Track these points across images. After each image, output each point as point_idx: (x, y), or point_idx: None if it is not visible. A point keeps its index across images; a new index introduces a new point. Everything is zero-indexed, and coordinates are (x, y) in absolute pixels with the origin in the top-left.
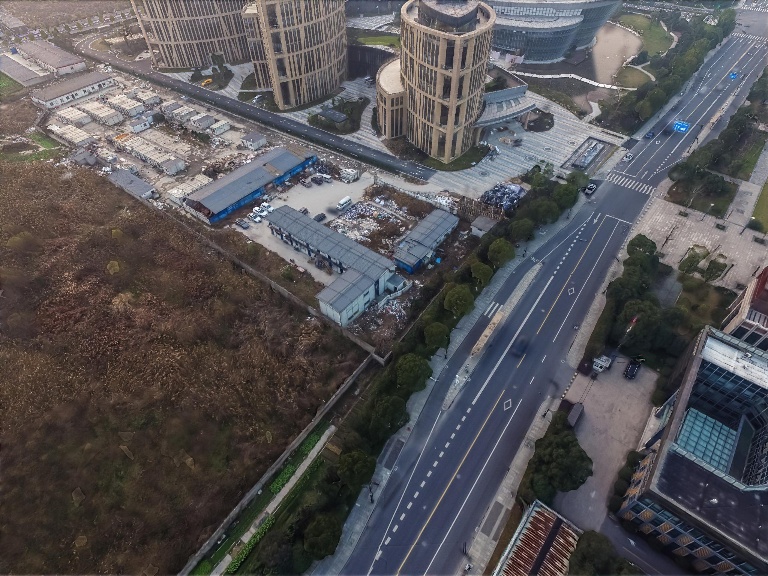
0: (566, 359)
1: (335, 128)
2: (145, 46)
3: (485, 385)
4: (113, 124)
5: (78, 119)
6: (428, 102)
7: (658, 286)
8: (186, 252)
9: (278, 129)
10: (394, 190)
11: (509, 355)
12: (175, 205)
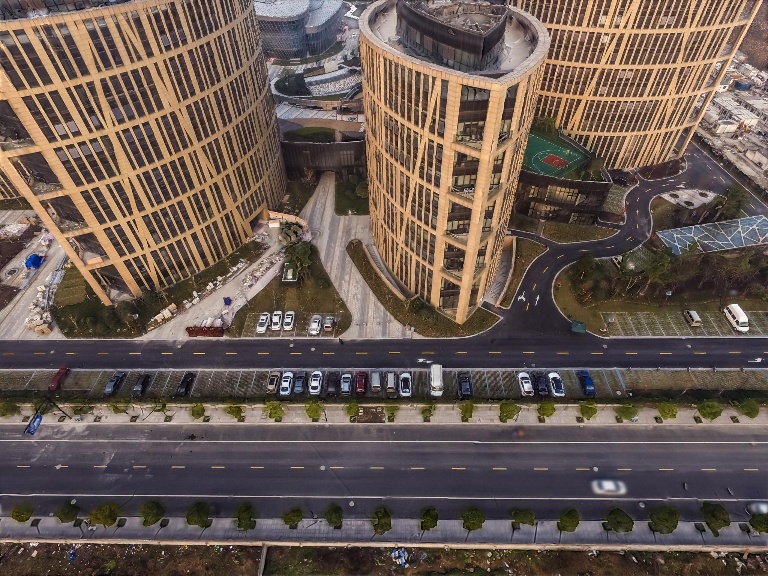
0: None
1: None
2: (691, 209)
3: None
4: None
5: None
6: None
7: None
8: None
9: None
10: None
11: None
12: None
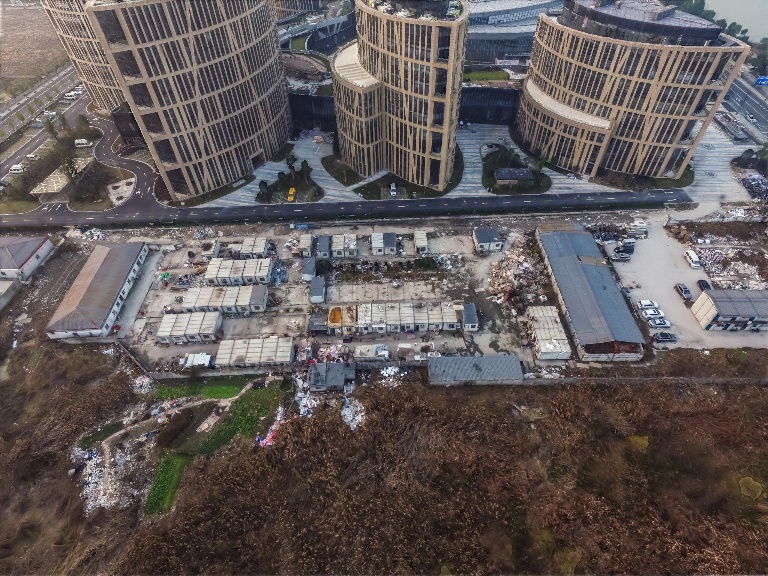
0: None
1: (531, 187)
2: (103, 179)
3: None
4: (265, 306)
5: (214, 326)
6: (670, 123)
7: None
8: (707, 408)
9: (480, 214)
10: (694, 224)
11: None
12: (558, 363)
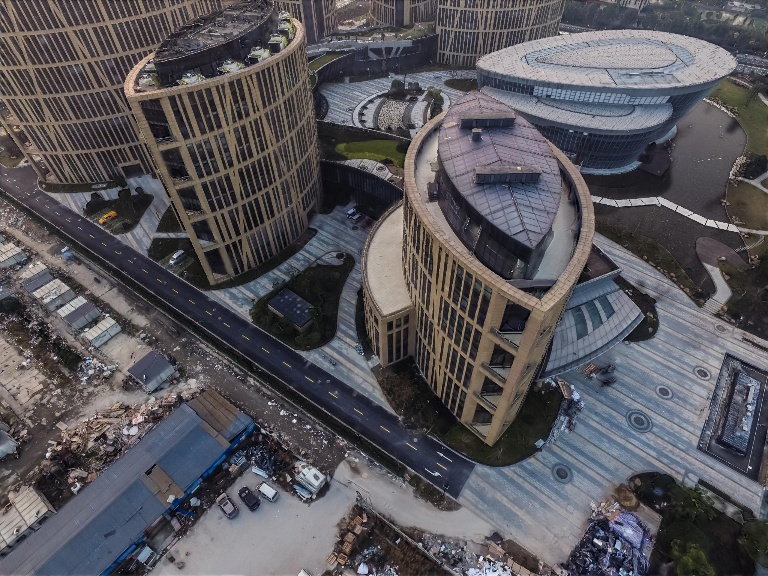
0: None
1: (294, 334)
2: None
3: None
4: None
5: None
6: (459, 358)
7: None
8: None
9: (199, 335)
10: (395, 534)
11: None
12: None
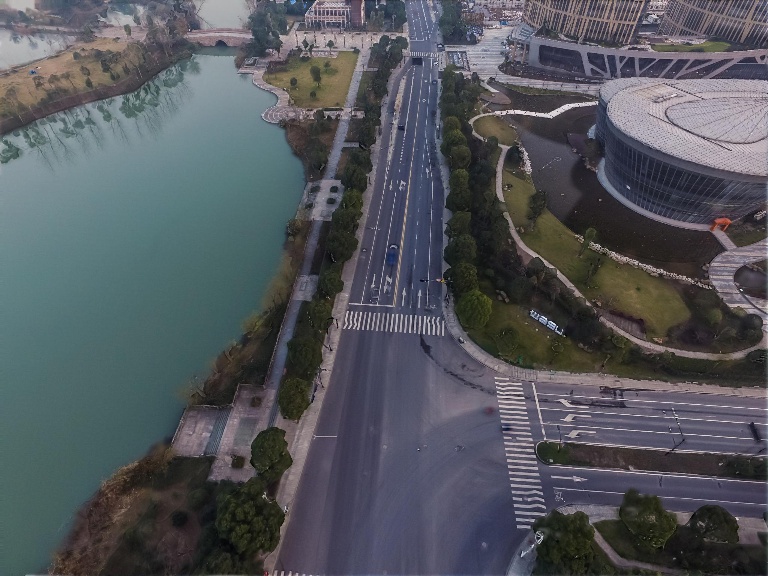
0: (405, 10)
1: None
2: None
3: (422, 3)
4: None
5: None
6: None
7: (388, 27)
8: None
9: None
10: None
11: (421, 7)
12: None
